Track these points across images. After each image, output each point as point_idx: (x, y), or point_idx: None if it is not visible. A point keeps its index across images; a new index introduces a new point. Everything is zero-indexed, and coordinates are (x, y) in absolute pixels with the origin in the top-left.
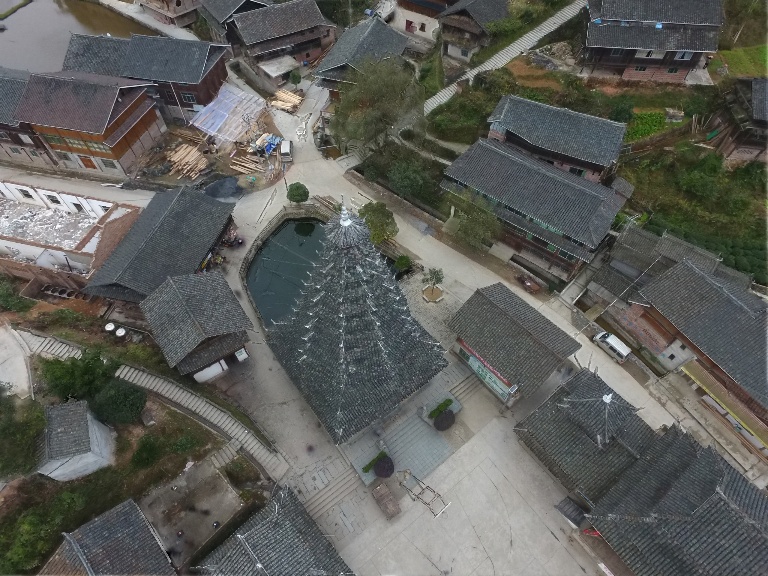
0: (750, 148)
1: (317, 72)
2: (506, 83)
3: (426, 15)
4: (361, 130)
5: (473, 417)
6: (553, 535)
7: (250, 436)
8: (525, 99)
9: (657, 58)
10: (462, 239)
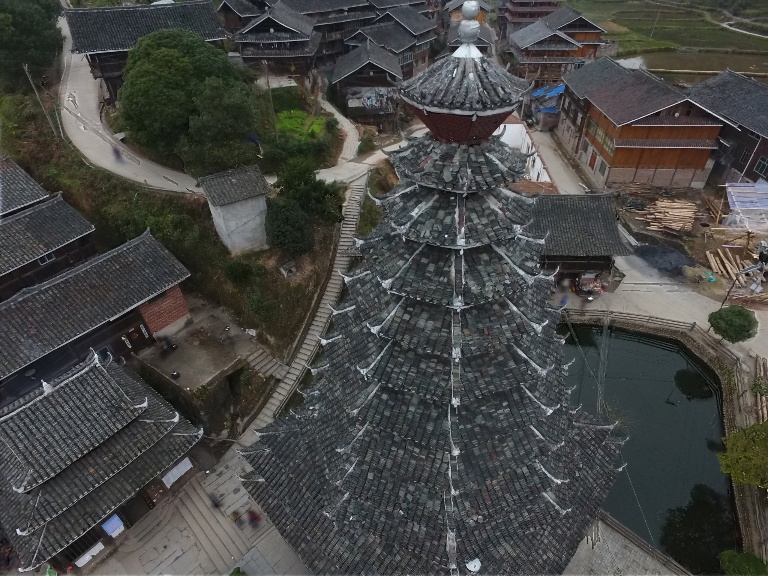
0: None
1: None
2: None
3: None
4: None
5: None
6: None
7: None
8: None
9: None
10: None
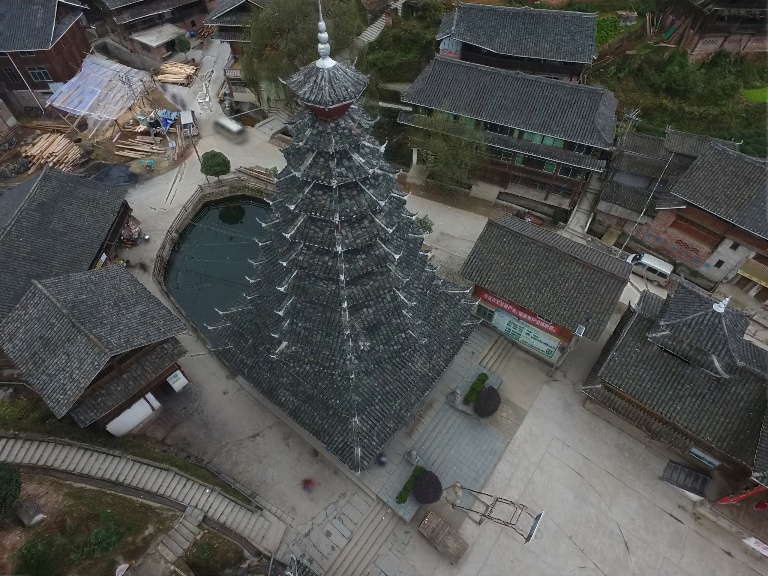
0: (715, 36)
1: (210, 19)
2: (442, 4)
3: None
4: (285, 61)
5: (518, 390)
6: (673, 518)
7: (215, 496)
8: (476, 4)
9: None
10: (434, 186)
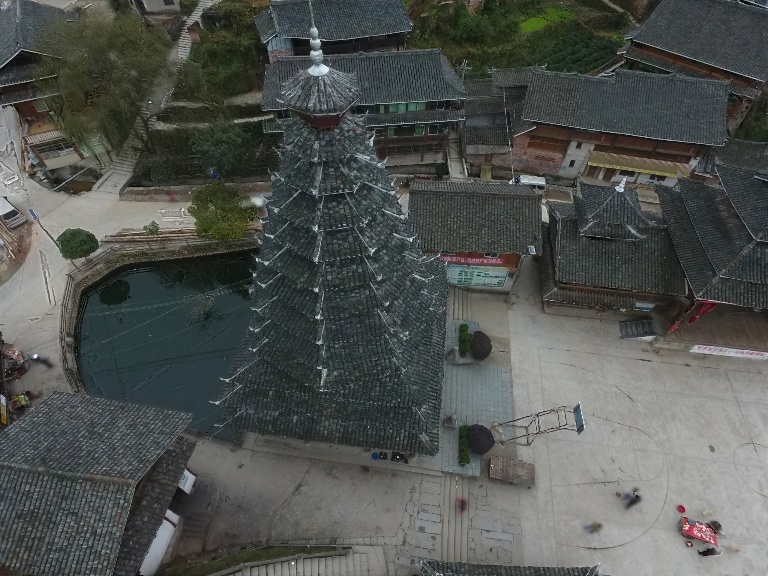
0: None
1: None
2: (244, 7)
3: None
4: (122, 103)
5: (492, 325)
6: (644, 361)
7: (302, 564)
8: None
9: None
10: None
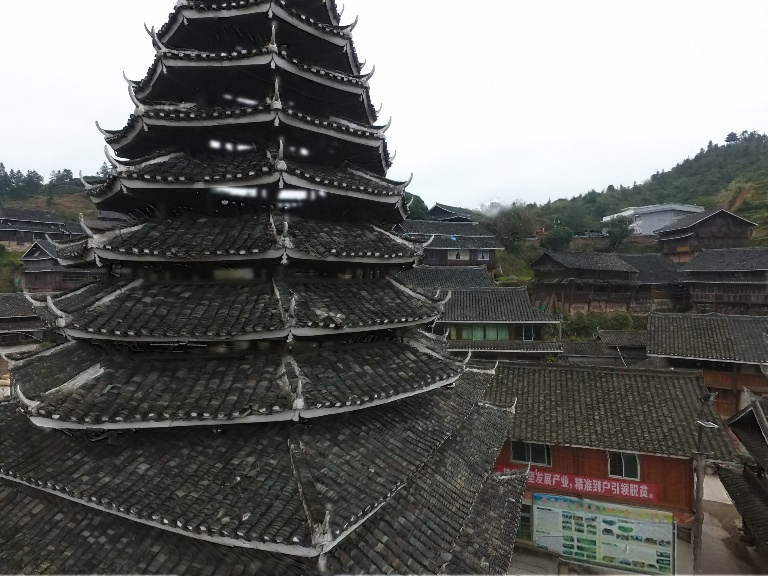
0: (580, 302)
1: None
2: None
3: None
4: None
5: None
6: None
7: None
8: None
9: (465, 259)
10: None
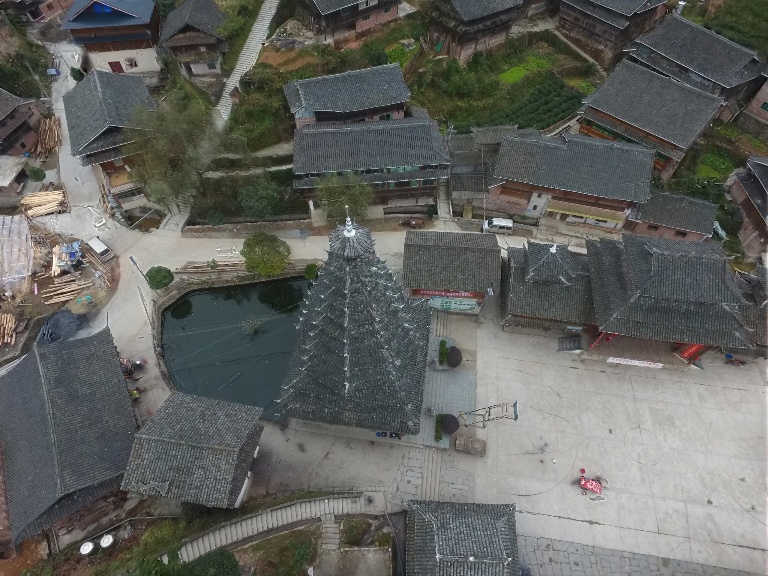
0: (470, 44)
1: (77, 151)
2: (274, 75)
3: (129, 49)
4: (194, 177)
5: (464, 340)
6: (573, 368)
7: (332, 501)
8: (312, 78)
9: (374, 4)
10: None
